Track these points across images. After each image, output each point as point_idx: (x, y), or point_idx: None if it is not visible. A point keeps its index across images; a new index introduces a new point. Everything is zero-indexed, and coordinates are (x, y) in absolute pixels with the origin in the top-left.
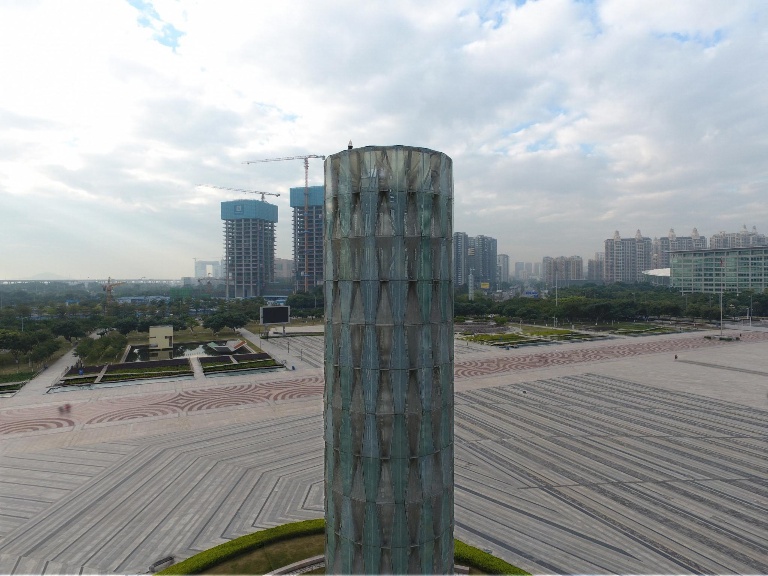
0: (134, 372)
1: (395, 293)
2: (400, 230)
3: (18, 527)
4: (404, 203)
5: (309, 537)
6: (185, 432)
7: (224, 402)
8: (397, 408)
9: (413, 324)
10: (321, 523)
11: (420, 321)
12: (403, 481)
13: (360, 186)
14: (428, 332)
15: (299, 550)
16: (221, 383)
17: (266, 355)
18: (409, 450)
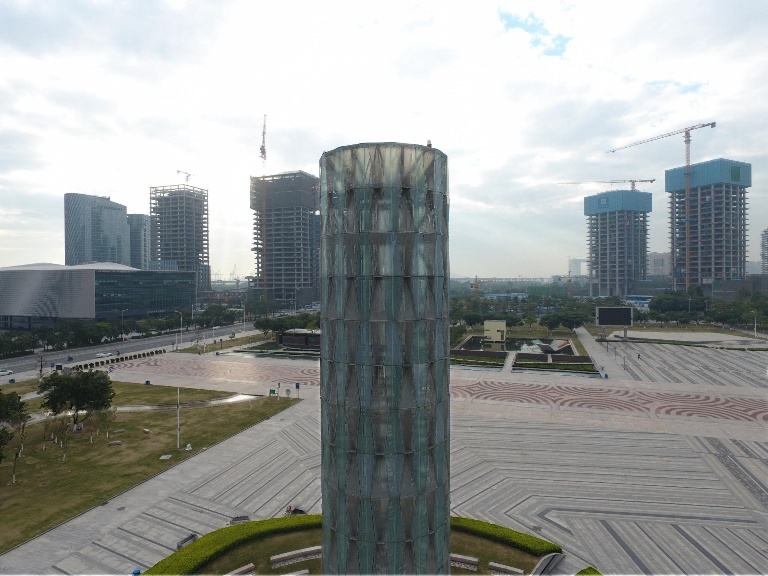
0: (459, 358)
1: (339, 289)
2: (341, 228)
3: (318, 450)
4: (344, 202)
5: (477, 538)
6: (460, 415)
7: (510, 397)
8: (340, 399)
9: (352, 320)
10: (498, 531)
11: (358, 317)
12: (344, 471)
13: (320, 191)
14: (368, 329)
15: (460, 544)
16: (521, 379)
17: (586, 359)
18: (349, 443)
